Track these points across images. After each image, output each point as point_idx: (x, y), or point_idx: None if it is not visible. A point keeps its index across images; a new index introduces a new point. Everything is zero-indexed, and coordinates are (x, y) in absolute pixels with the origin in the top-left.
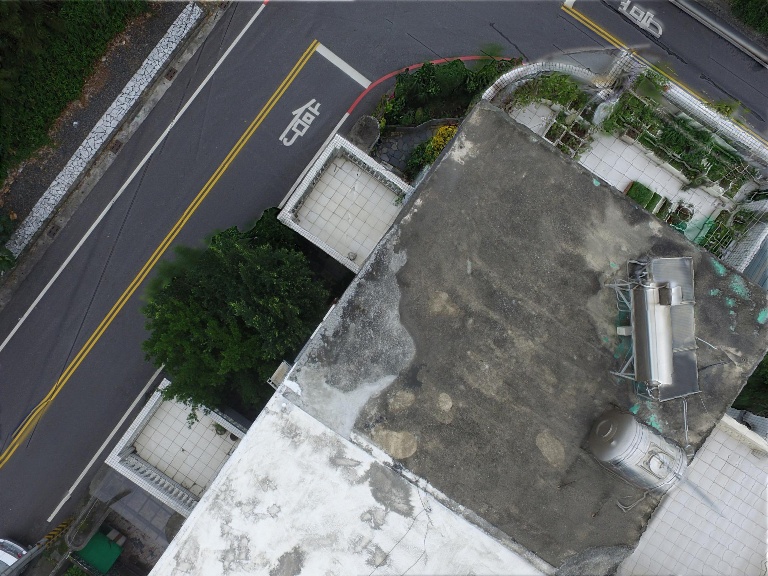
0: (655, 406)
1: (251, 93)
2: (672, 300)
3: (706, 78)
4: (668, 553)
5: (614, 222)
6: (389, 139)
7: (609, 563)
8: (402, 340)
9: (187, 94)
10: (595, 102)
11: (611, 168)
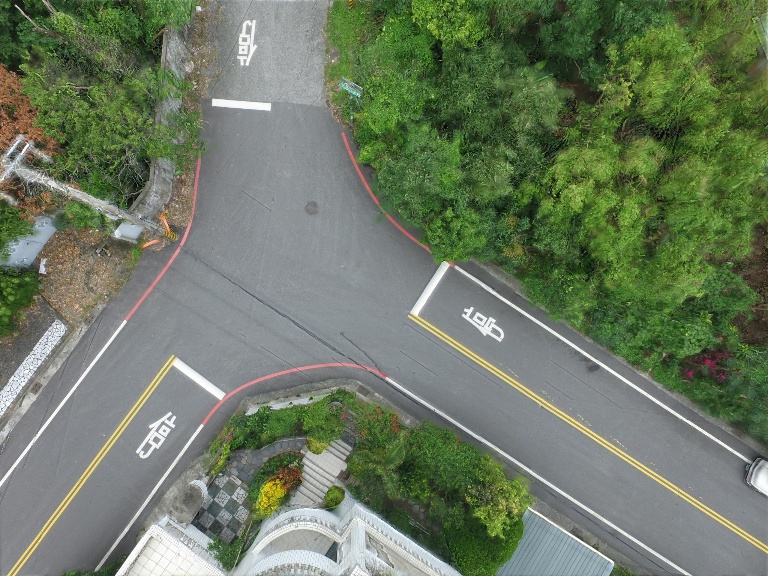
0: None
1: (110, 408)
2: None
3: None
4: None
5: None
6: (239, 453)
7: None
8: None
9: (50, 409)
10: None
11: None
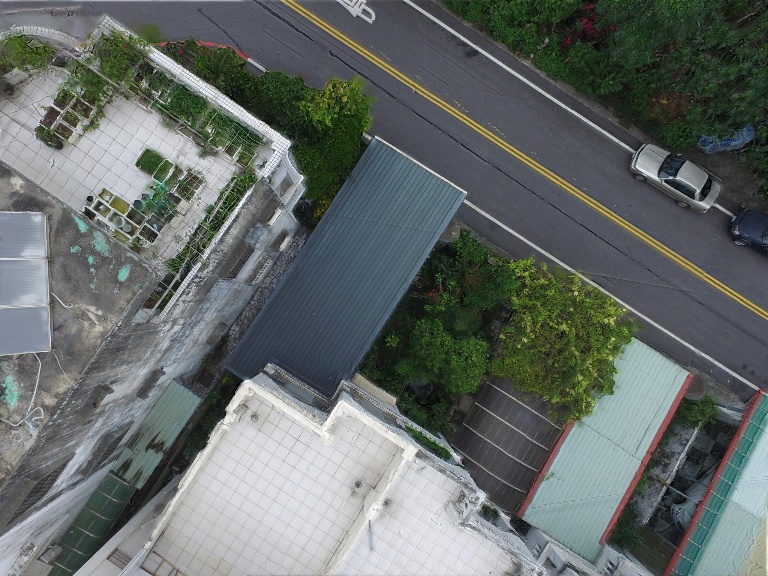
0: (10, 367)
1: None
2: None
3: (334, 55)
4: (236, 535)
5: None
6: None
7: None
8: None
9: None
10: None
11: (131, 136)
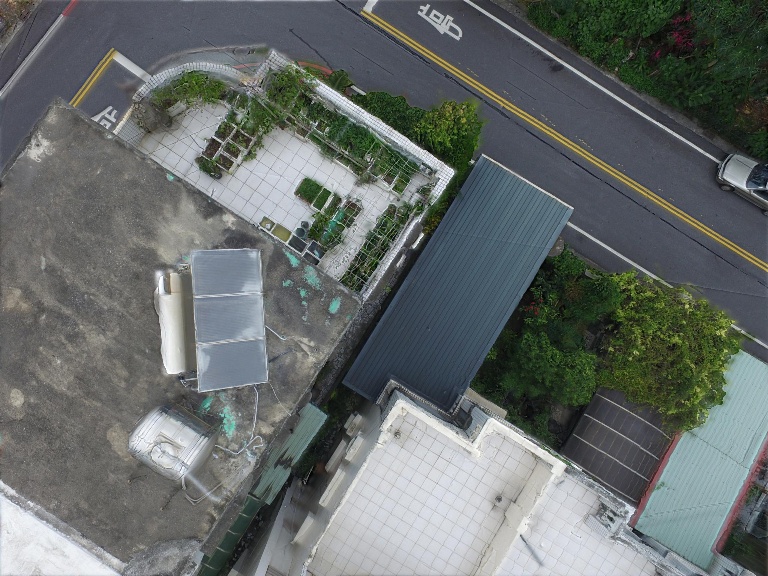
0: (228, 398)
1: (47, 101)
2: (159, 289)
3: None
4: (382, 550)
5: (186, 216)
6: None
7: (178, 557)
8: None
9: None
10: None
11: (287, 165)
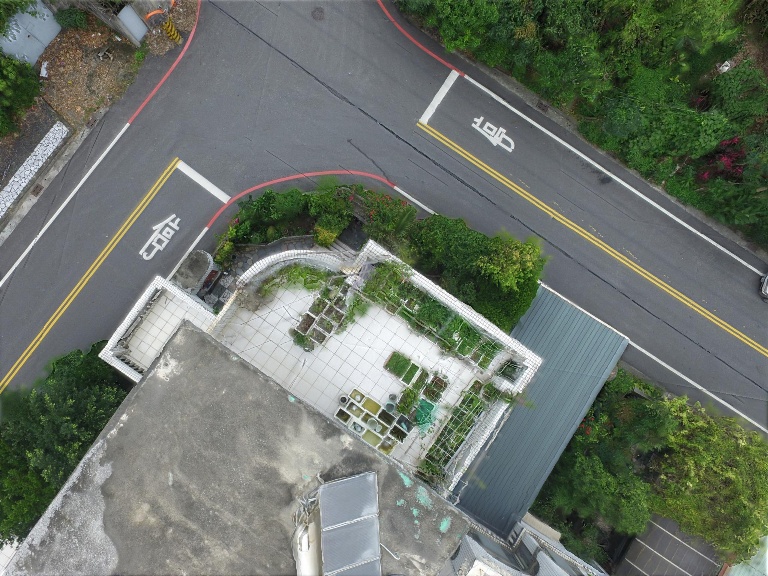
0: None
1: (113, 209)
2: (302, 547)
3: (515, 218)
4: None
5: (307, 436)
6: (245, 254)
7: None
8: (105, 549)
9: (52, 210)
10: (348, 284)
11: (376, 337)
